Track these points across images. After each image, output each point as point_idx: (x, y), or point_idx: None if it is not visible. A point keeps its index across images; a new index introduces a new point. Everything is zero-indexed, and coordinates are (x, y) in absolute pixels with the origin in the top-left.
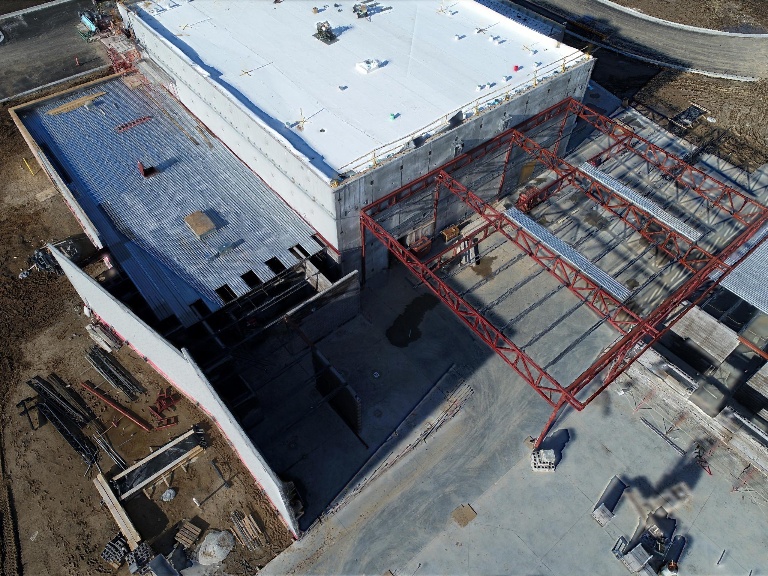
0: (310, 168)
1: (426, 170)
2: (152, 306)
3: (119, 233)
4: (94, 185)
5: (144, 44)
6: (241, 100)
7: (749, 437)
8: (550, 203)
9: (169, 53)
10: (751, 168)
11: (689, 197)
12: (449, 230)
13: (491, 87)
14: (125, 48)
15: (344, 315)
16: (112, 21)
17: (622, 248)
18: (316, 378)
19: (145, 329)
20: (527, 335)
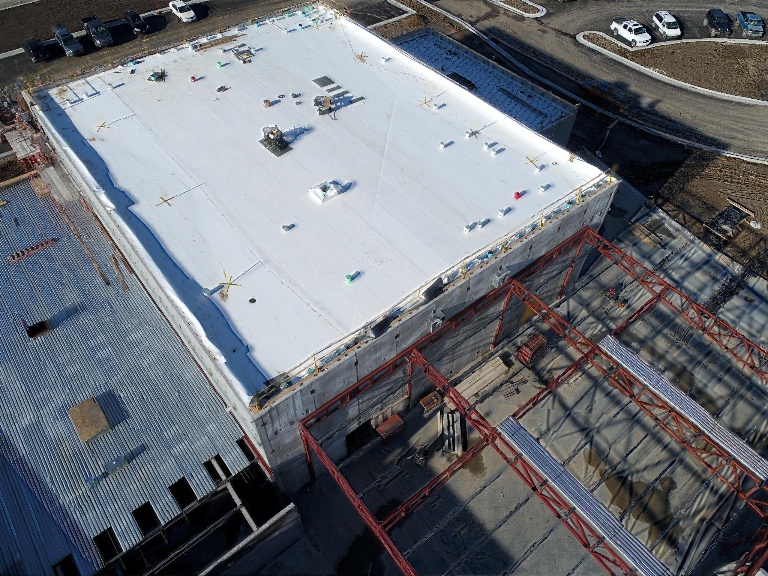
0: (225, 375)
1: (393, 353)
2: (1, 567)
3: None
4: None
5: (53, 144)
6: (151, 247)
7: None
8: (559, 351)
9: (73, 167)
10: None
11: (735, 343)
12: (428, 400)
13: (483, 226)
14: (27, 151)
15: (281, 546)
16: None
17: (652, 424)
18: None
19: None
20: (528, 574)
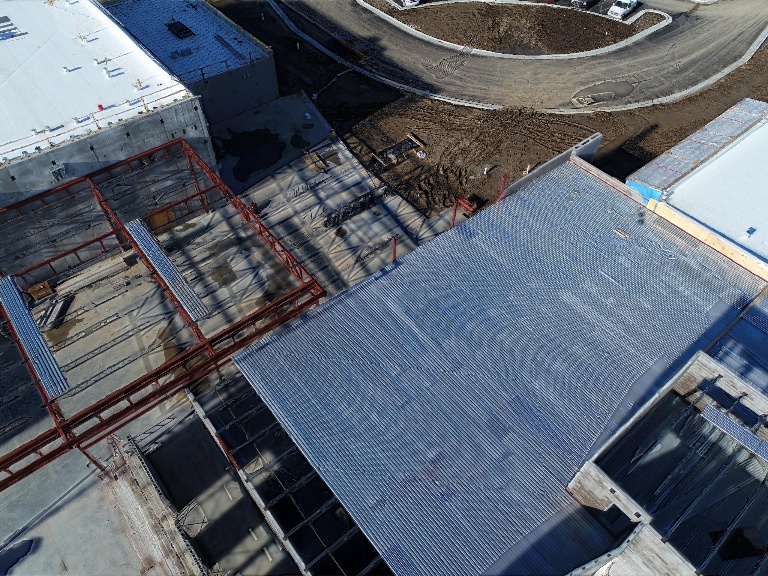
0: None
1: None
2: None
3: None
4: None
5: None
6: None
7: (173, 566)
8: (182, 254)
9: None
10: (434, 212)
11: (343, 247)
12: (36, 288)
13: (53, 131)
14: None
15: None
16: None
17: (232, 309)
18: None
19: None
20: None
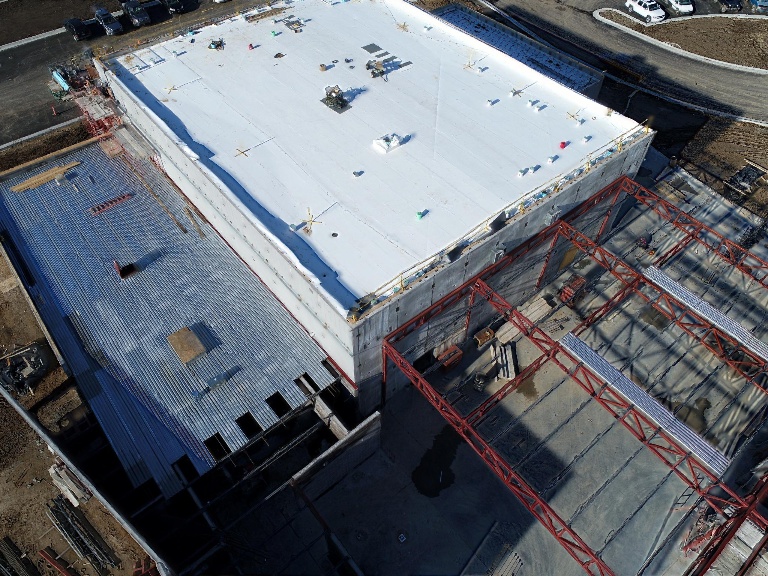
0: (321, 294)
1: (461, 281)
2: (125, 465)
3: (88, 357)
4: (61, 288)
5: (124, 107)
6: (236, 191)
7: None
8: (597, 293)
9: (152, 125)
10: None
11: (758, 284)
12: (482, 334)
13: (535, 171)
14: (102, 113)
15: (361, 456)
16: (89, 76)
17: None
18: (331, 574)
19: (113, 515)
20: (583, 479)
